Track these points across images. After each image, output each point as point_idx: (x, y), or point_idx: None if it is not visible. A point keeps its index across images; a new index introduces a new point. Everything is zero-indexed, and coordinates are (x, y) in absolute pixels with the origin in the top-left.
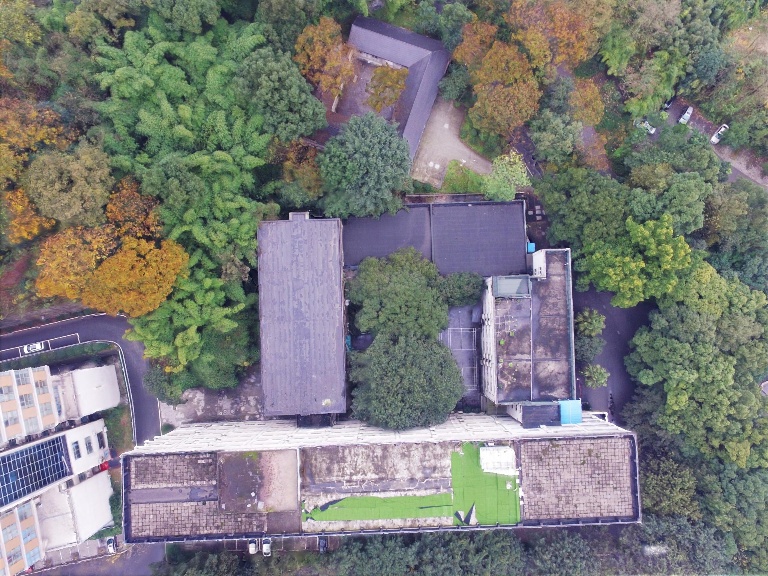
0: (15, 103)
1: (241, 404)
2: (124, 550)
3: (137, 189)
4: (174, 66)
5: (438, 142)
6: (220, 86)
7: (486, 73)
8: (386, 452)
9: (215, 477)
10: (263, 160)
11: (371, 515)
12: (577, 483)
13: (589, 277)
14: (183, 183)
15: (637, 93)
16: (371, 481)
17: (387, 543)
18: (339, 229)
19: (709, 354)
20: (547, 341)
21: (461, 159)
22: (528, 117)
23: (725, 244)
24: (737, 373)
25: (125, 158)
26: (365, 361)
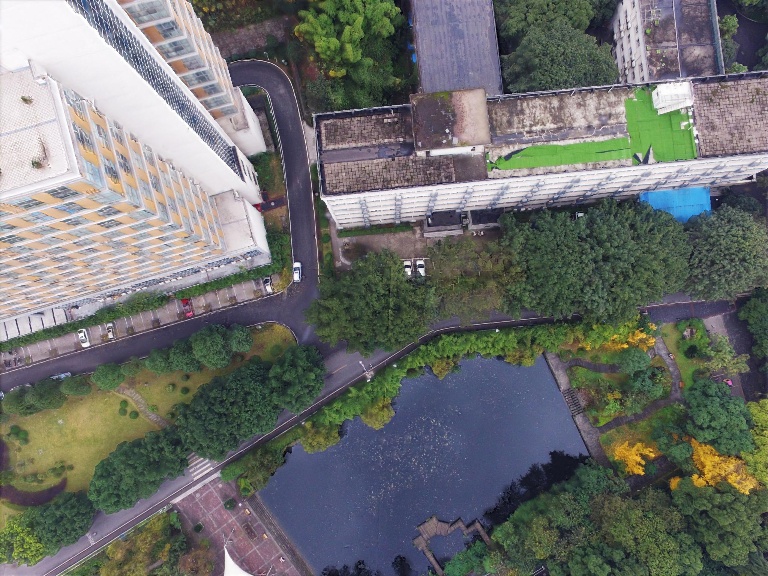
0: None
1: None
2: (280, 291)
3: None
4: None
5: None
6: None
7: None
8: (562, 103)
9: (402, 134)
10: None
11: (553, 162)
12: (748, 120)
13: None
14: None
15: None
16: (550, 131)
17: (558, 216)
18: None
19: None
20: (691, 28)
21: None
22: None
23: None
24: None
25: None
26: (521, 50)
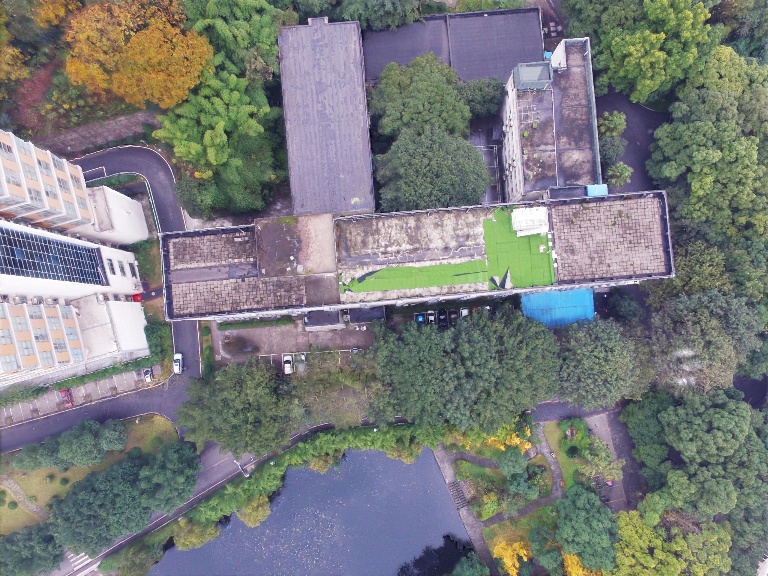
0: None
1: None
2: (161, 382)
3: None
4: None
5: None
6: None
7: None
8: (419, 223)
9: (252, 254)
10: None
11: (408, 284)
12: (609, 243)
13: (608, 74)
14: None
15: None
16: (406, 252)
17: (423, 329)
18: (359, 31)
19: (732, 131)
20: (570, 131)
21: None
22: None
23: (742, 27)
24: (760, 157)
25: None
26: (392, 155)
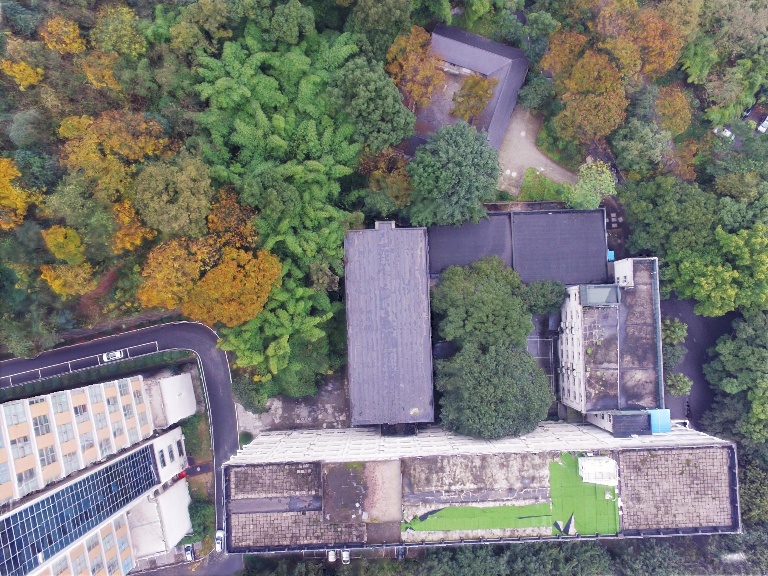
0: (127, 115)
1: (318, 412)
2: (201, 557)
3: (236, 200)
4: (268, 76)
5: (515, 150)
6: (312, 96)
7: (577, 82)
8: (485, 462)
9: (314, 487)
10: (351, 169)
11: (470, 525)
12: (676, 493)
13: (672, 285)
14: (279, 193)
15: (720, 101)
16: (470, 491)
17: (478, 552)
18: (426, 238)
19: None
20: (634, 350)
21: (538, 167)
22: (616, 126)
23: None
24: None
25: (222, 168)
26: (454, 370)
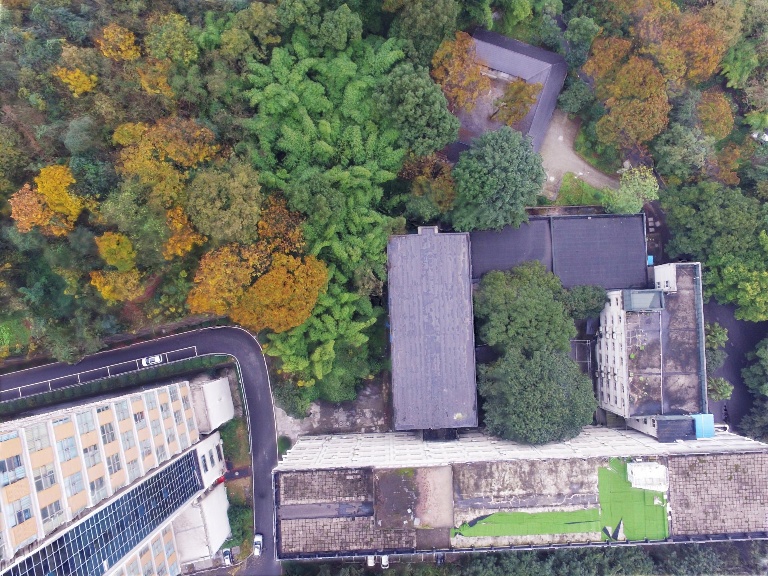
0: (182, 122)
1: (357, 416)
2: (239, 562)
3: (285, 206)
4: (315, 82)
5: (553, 154)
6: (357, 101)
7: (622, 88)
8: (533, 468)
9: (364, 493)
10: (395, 175)
11: (519, 531)
12: (724, 499)
13: (713, 290)
14: (327, 199)
15: (761, 106)
16: (518, 497)
17: (523, 557)
18: (468, 243)
19: None
20: (677, 355)
21: (575, 171)
22: (659, 131)
23: None
24: None
25: (271, 174)
26: (498, 375)
